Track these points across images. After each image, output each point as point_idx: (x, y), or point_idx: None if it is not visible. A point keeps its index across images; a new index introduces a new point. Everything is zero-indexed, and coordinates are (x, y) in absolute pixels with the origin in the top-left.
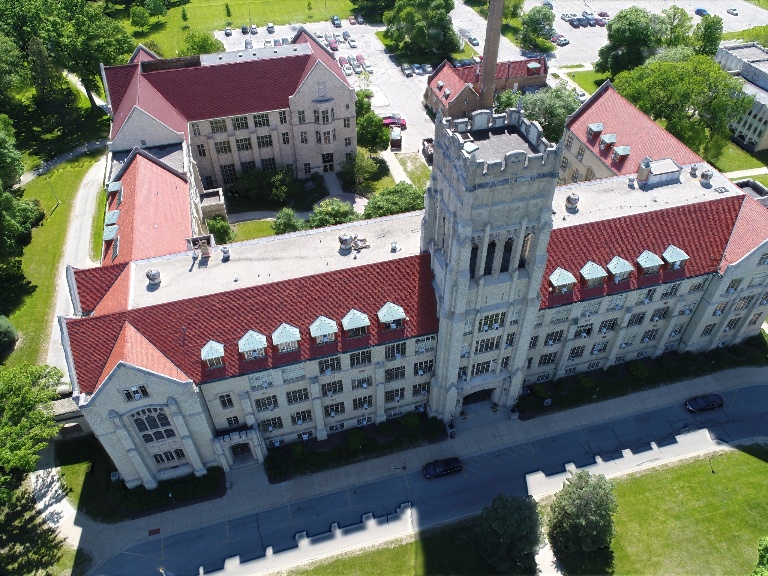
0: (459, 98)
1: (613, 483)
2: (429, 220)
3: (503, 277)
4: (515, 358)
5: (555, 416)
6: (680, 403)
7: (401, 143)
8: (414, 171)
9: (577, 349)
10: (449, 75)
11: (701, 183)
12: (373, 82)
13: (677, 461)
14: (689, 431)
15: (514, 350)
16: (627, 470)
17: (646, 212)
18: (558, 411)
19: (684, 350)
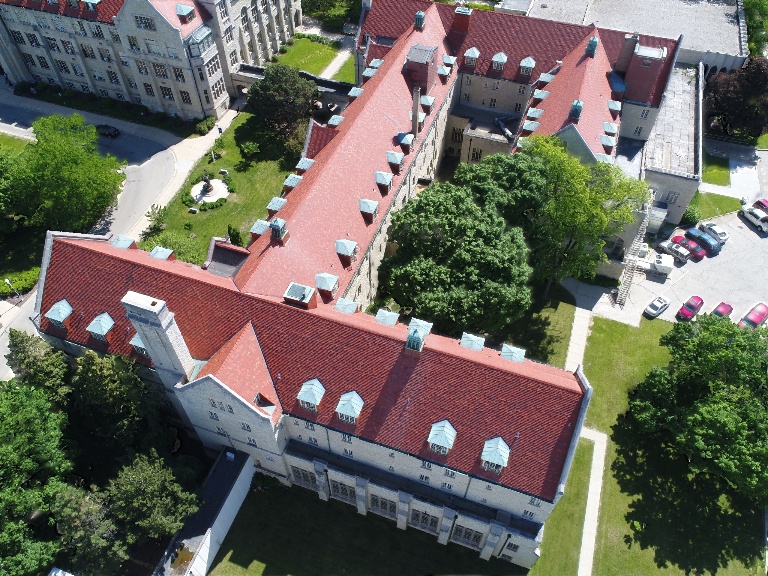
0: None
1: (0, 134)
2: None
3: None
4: None
5: (31, 100)
6: None
7: None
8: None
9: (63, 64)
10: None
11: None
12: None
13: None
14: None
15: None
16: (17, 134)
17: None
18: (36, 99)
19: (142, 104)
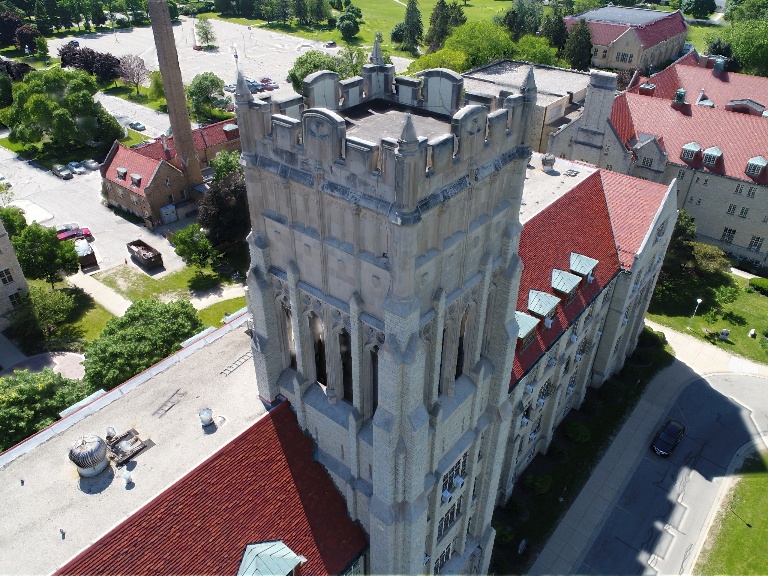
0: (157, 180)
1: None
2: (270, 336)
3: (461, 389)
4: (484, 514)
5: (541, 562)
6: (646, 452)
7: (95, 259)
8: (133, 289)
9: None
10: (130, 157)
11: (546, 172)
12: (16, 196)
13: (709, 536)
14: (683, 484)
15: (480, 502)
16: None
17: (531, 219)
18: (539, 551)
19: (602, 382)
